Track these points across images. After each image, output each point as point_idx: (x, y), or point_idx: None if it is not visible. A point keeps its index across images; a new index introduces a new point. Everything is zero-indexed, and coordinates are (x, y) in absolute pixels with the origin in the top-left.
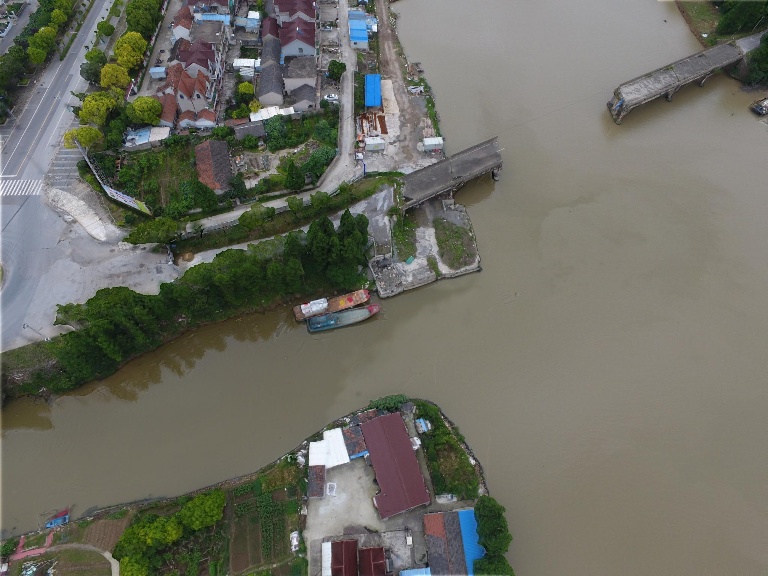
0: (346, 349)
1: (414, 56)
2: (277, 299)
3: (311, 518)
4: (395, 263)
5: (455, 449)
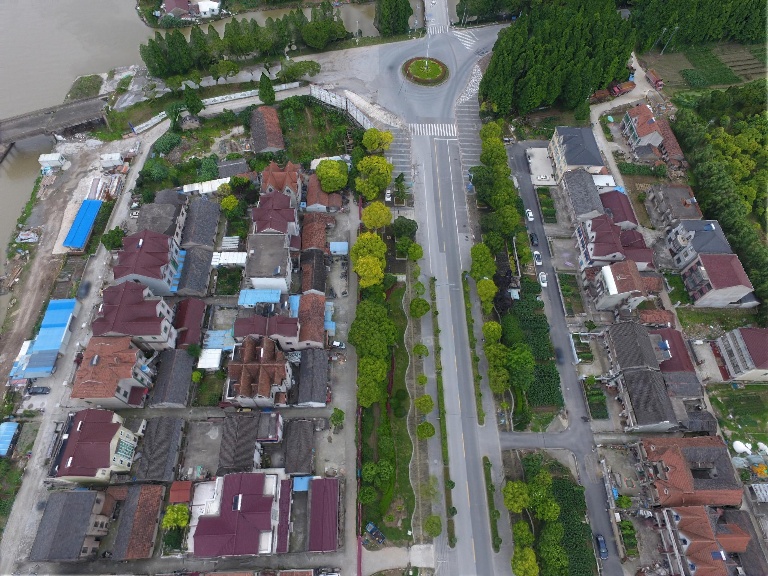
0: None
1: None
2: None
3: None
4: None
5: None
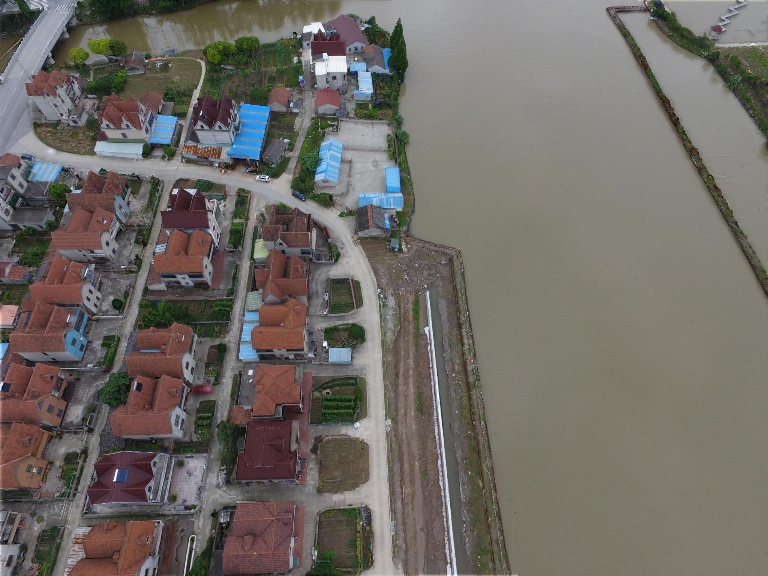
0: (325, 9)
1: None
2: None
3: (304, 54)
4: None
5: (384, 36)
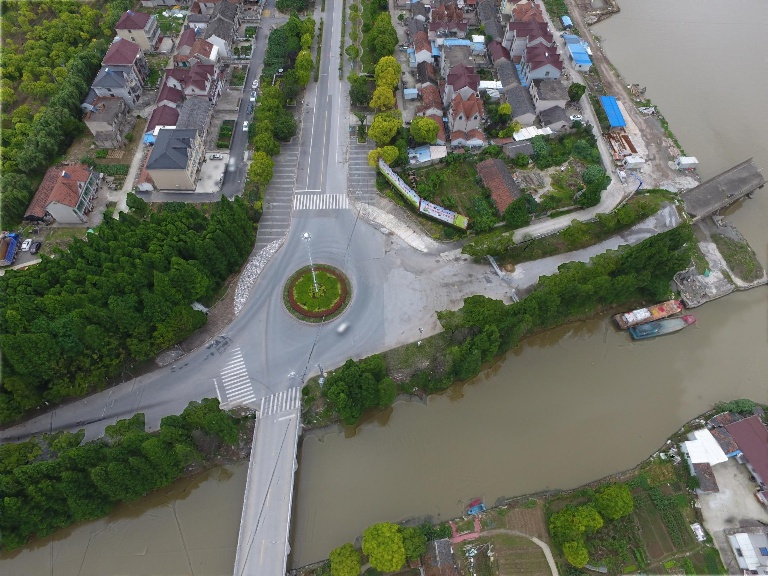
0: (666, 356)
1: (629, 78)
2: (598, 308)
3: (705, 511)
4: (695, 276)
5: None
